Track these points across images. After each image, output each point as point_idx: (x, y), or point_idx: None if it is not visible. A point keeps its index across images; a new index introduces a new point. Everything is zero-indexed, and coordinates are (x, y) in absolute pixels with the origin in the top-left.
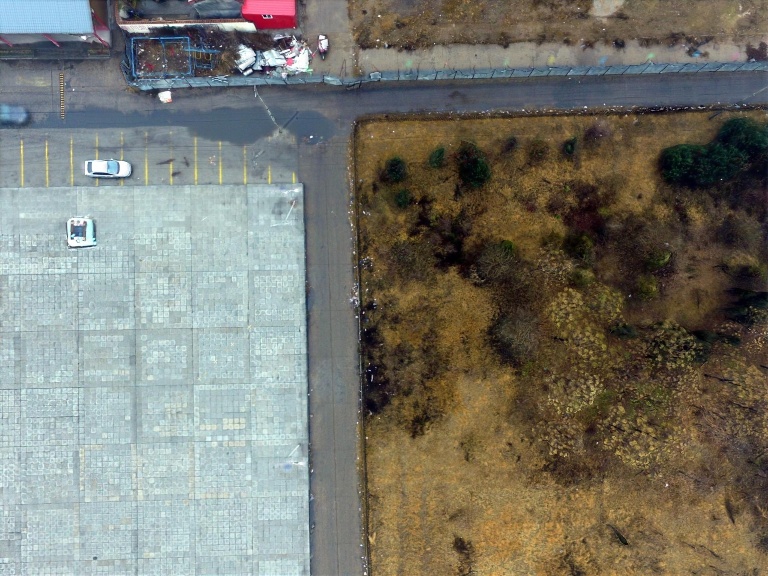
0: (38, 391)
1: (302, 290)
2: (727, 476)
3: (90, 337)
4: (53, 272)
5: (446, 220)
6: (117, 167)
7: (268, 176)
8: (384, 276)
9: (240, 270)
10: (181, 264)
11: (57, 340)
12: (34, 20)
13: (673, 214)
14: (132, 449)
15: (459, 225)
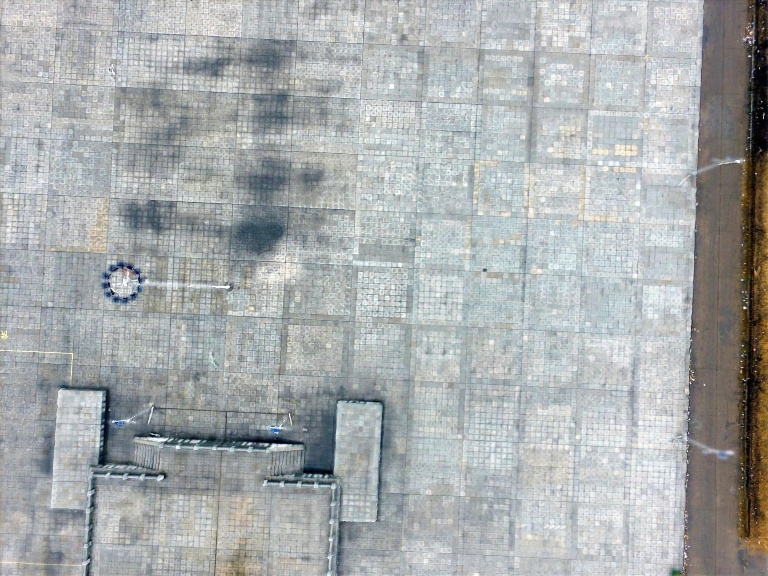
0: (438, 105)
1: (700, 24)
2: None
3: (491, 56)
4: None
5: None
6: None
7: None
8: None
9: None
10: None
11: (459, 57)
12: None
13: None
14: (525, 168)
15: None
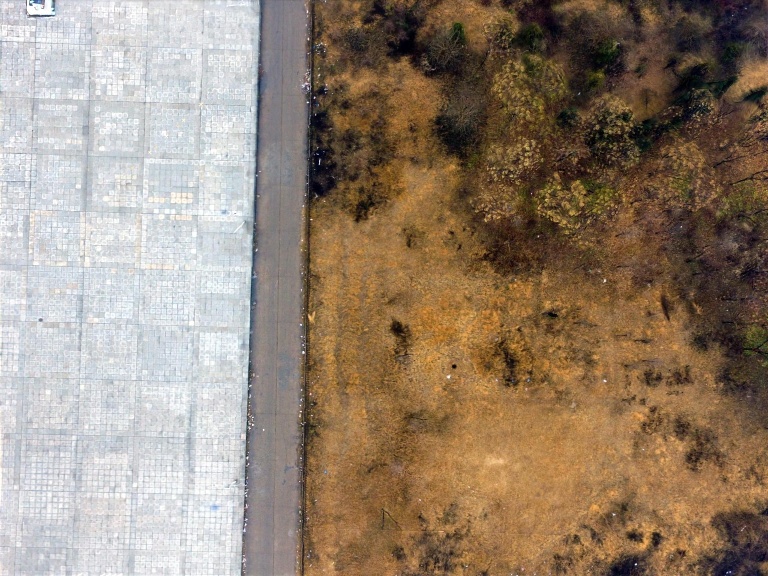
0: None
1: (255, 71)
2: (665, 273)
3: (45, 105)
4: (11, 40)
5: (400, 8)
6: None
7: None
8: (336, 62)
9: (195, 48)
10: (137, 39)
11: (13, 106)
12: None
13: (627, 15)
14: (81, 217)
15: (413, 15)
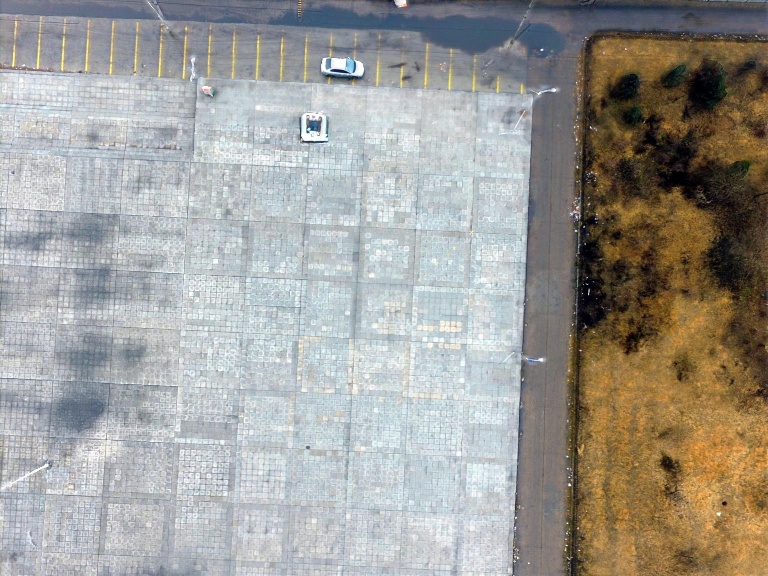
0: (263, 280)
1: (526, 200)
2: None
3: (316, 231)
4: (284, 165)
5: (675, 139)
6: (353, 66)
7: (496, 86)
8: (607, 192)
9: (466, 176)
10: (409, 166)
11: (284, 232)
12: None
13: None
14: (350, 344)
15: (685, 146)
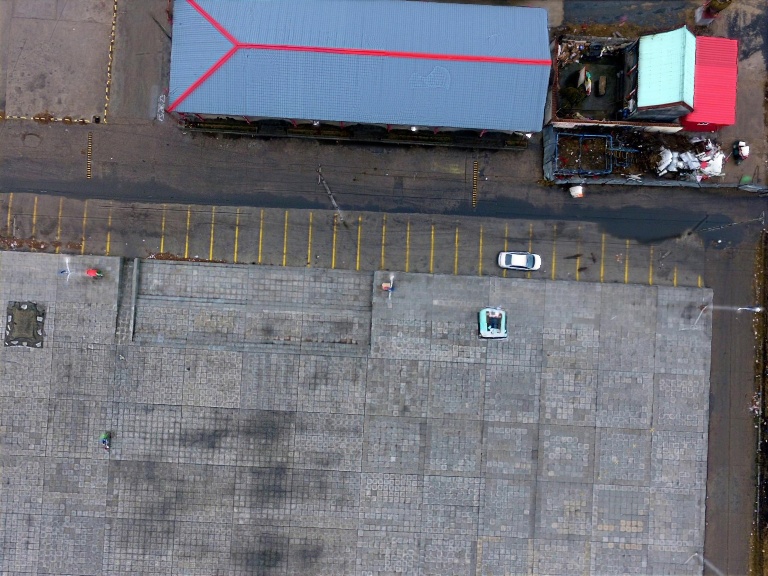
0: (441, 478)
1: (707, 396)
2: None
3: (494, 428)
4: (462, 361)
5: None
6: (532, 261)
7: (673, 278)
8: None
9: (646, 372)
10: (588, 362)
11: (462, 429)
12: (486, 116)
13: None
14: (529, 544)
15: None
